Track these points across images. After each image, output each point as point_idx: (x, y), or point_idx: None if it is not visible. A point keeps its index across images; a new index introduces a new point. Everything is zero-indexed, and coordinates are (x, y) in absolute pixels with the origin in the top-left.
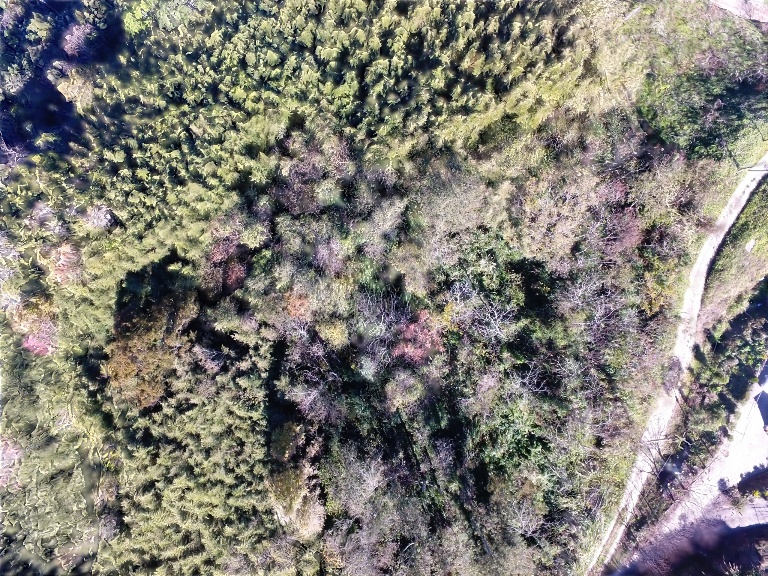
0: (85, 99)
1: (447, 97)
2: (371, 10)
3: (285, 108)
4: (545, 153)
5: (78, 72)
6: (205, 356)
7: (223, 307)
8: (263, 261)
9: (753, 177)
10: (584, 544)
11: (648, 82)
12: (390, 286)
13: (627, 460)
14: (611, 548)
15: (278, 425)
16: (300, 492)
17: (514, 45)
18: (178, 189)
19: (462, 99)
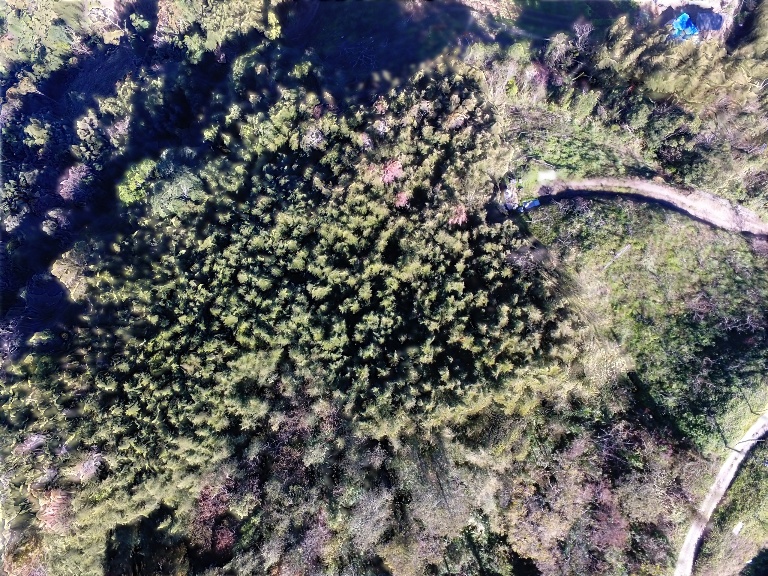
0: (78, 291)
1: (436, 373)
2: (362, 246)
3: (276, 348)
4: (534, 420)
5: (72, 255)
6: None
7: None
8: (252, 530)
9: (741, 448)
10: None
11: (638, 326)
12: None
13: None
14: None
15: None
16: None
17: (502, 332)
18: (168, 440)
19: (450, 384)
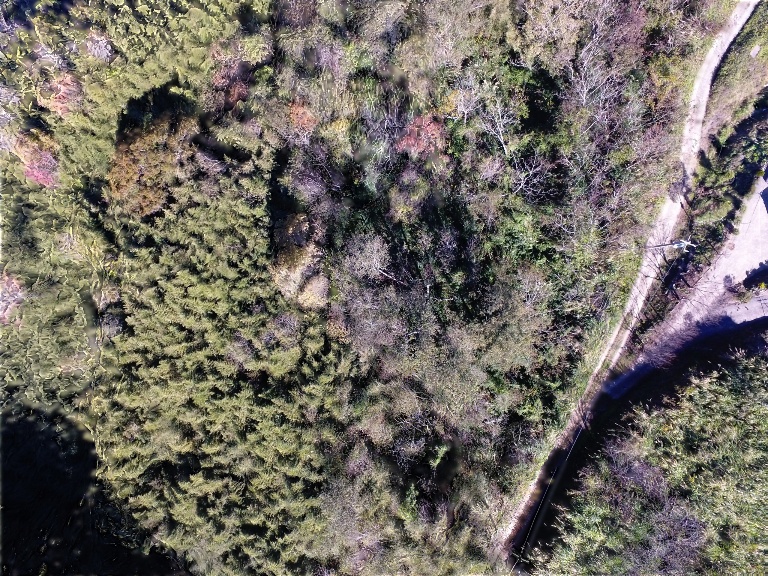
0: None
1: None
2: None
3: None
4: None
5: None
6: (207, 165)
7: (225, 122)
8: (265, 76)
9: None
10: (589, 343)
11: None
12: (393, 86)
13: (632, 262)
14: (616, 353)
15: (281, 217)
16: (304, 262)
17: None
18: (179, 16)
19: None
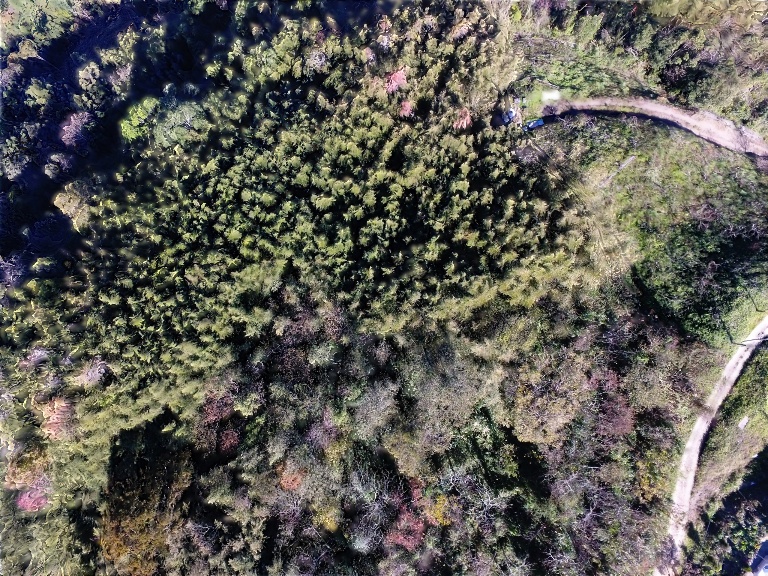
0: (81, 219)
1: (441, 270)
2: (366, 158)
3: (280, 258)
4: (539, 320)
5: (75, 187)
6: (198, 531)
7: (216, 476)
8: (257, 429)
9: (747, 347)
10: None
11: (642, 235)
12: (383, 469)
13: None
14: None
15: None
16: None
17: (508, 224)
18: (172, 346)
19: (456, 278)
